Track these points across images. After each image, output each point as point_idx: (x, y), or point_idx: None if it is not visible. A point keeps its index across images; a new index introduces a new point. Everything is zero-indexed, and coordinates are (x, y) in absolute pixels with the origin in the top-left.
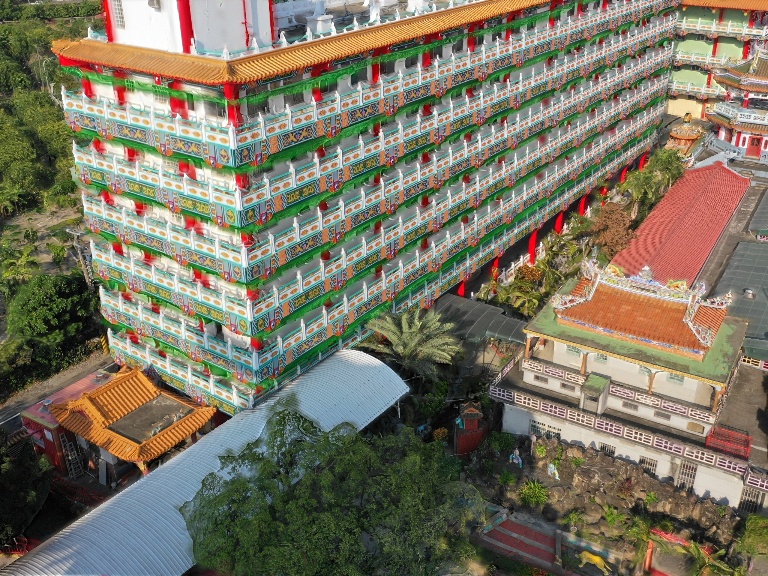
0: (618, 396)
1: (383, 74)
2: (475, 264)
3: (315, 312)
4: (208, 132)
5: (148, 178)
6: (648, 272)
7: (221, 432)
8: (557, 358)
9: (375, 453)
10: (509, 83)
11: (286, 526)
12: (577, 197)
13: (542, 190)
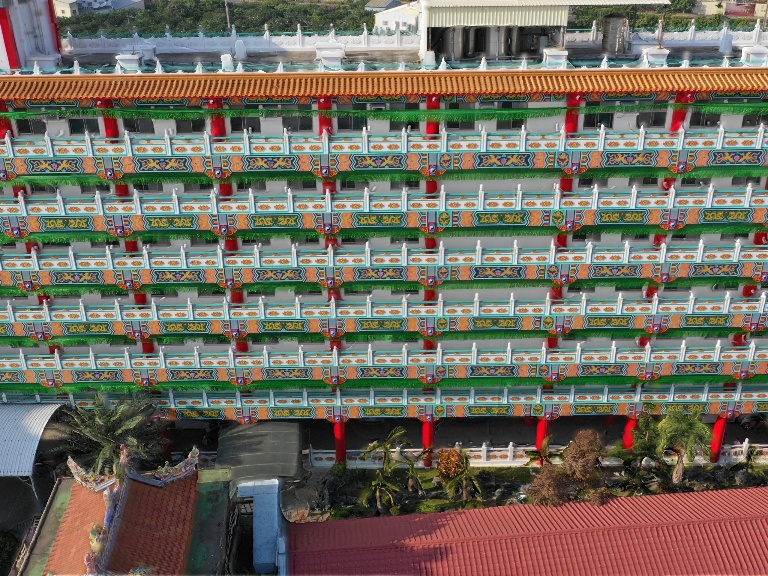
0: None
1: (133, 132)
2: (356, 409)
3: (14, 350)
4: None
5: None
6: (104, 497)
7: None
8: None
9: None
10: (405, 193)
11: None
12: (677, 410)
13: (529, 365)
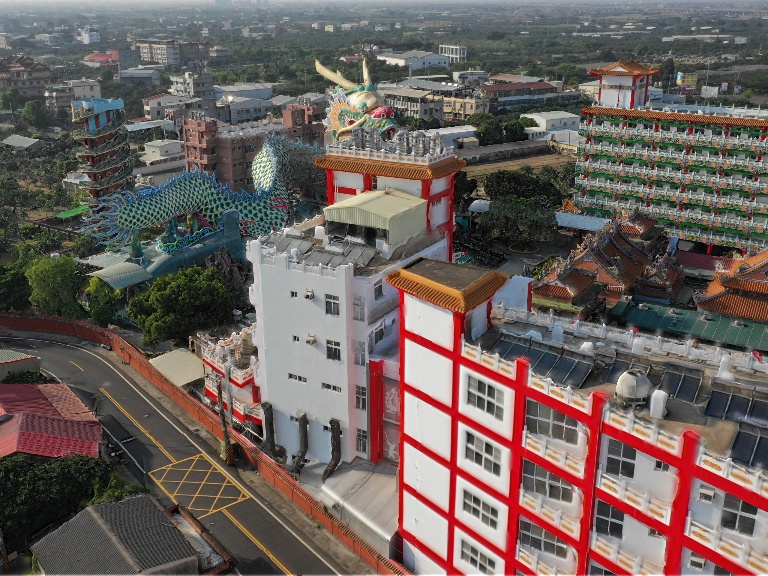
0: None
1: None
2: (717, 241)
3: None
4: None
5: None
6: (633, 208)
7: None
8: None
9: None
10: (749, 159)
11: None
12: None
13: None
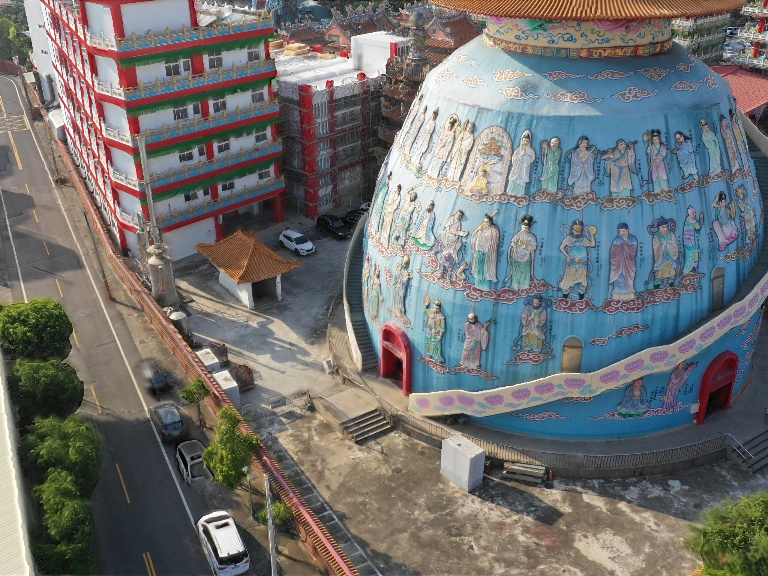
0: None
1: None
2: None
3: None
4: None
5: None
6: (415, 1)
7: None
8: None
9: None
10: None
11: None
12: None
13: None
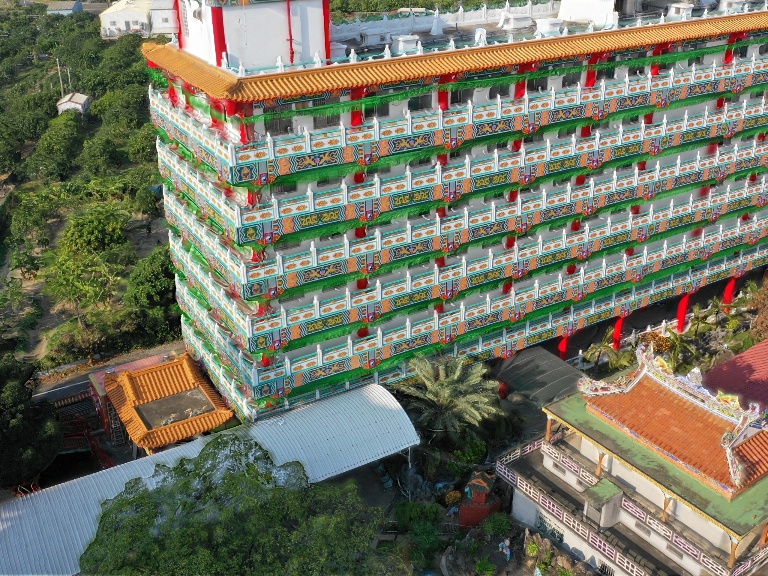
0: (629, 512)
1: (456, 103)
2: (582, 320)
3: (339, 340)
4: (218, 146)
5: (192, 181)
6: (697, 375)
7: (210, 438)
8: (584, 449)
9: (300, 502)
10: (644, 125)
11: (161, 551)
12: (759, 264)
13: (694, 250)
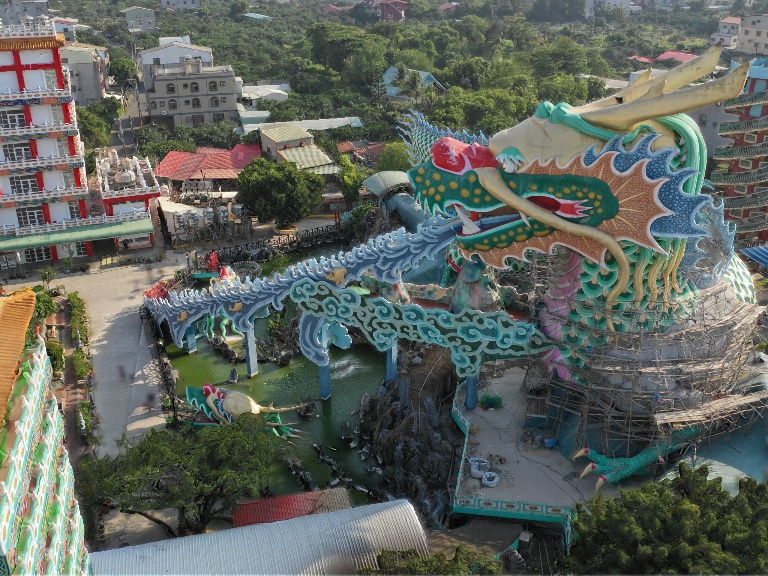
0: None
1: None
2: None
3: None
4: None
5: None
6: None
7: None
8: None
9: None
10: None
11: None
12: None
13: None
